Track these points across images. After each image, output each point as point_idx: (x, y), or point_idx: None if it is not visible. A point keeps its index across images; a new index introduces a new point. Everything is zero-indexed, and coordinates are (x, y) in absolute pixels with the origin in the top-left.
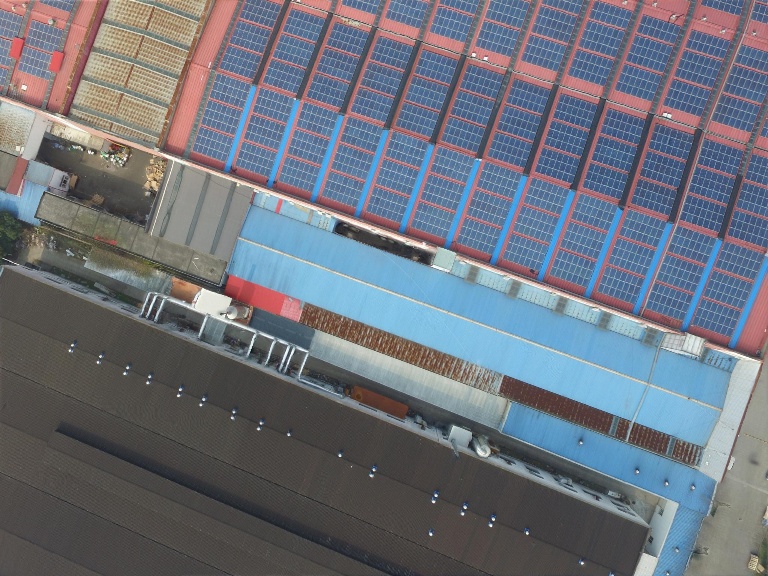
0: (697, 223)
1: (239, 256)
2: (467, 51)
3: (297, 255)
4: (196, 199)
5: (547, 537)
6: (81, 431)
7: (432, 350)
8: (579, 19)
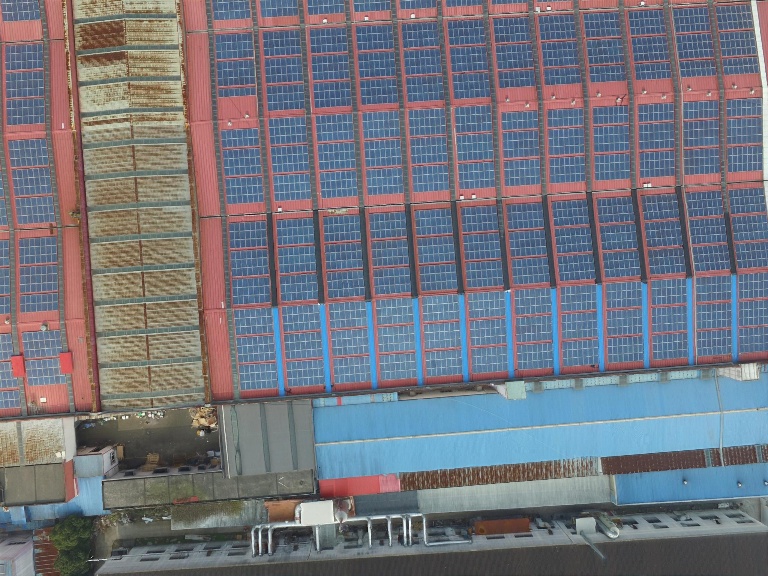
0: (710, 269)
1: (322, 460)
2: (454, 196)
3: (376, 436)
4: (258, 427)
5: None
6: None
7: (529, 462)
8: (540, 131)
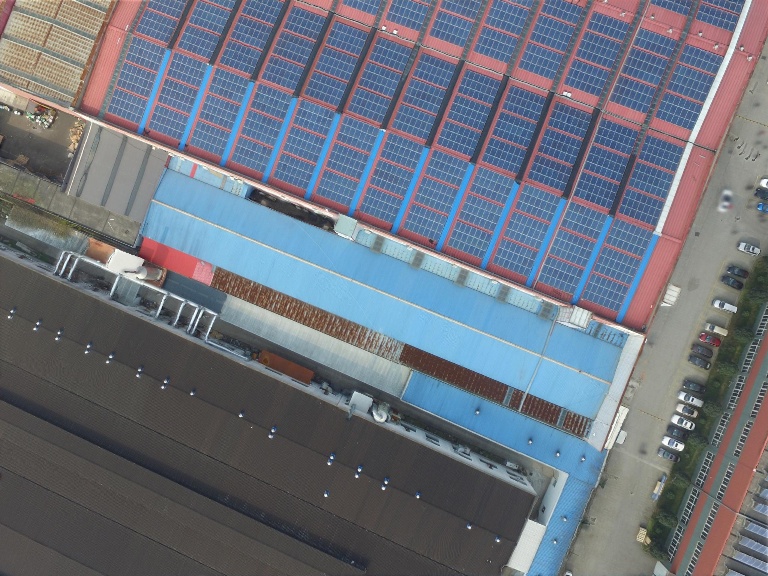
0: (590, 199)
1: (153, 218)
2: (378, 24)
3: (209, 219)
4: (113, 161)
5: (437, 501)
6: None
7: (338, 317)
8: None
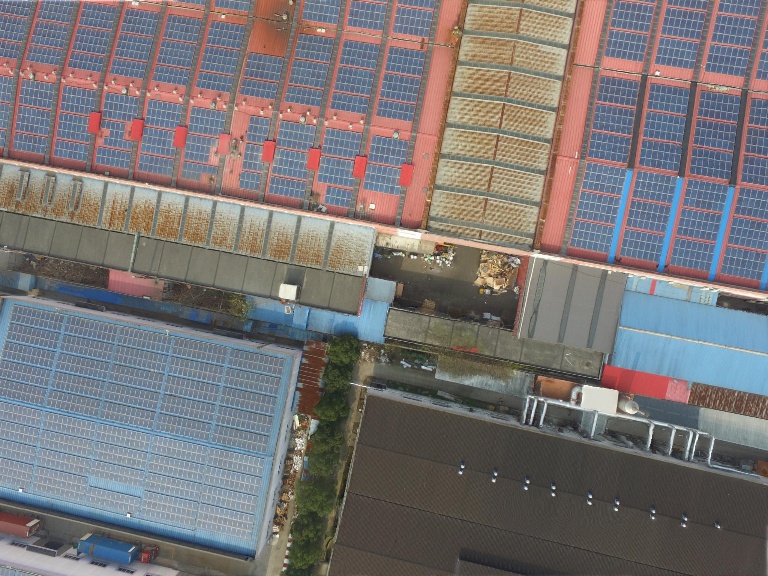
0: None
1: (620, 346)
2: None
3: (686, 336)
4: (564, 293)
5: None
6: (485, 555)
7: None
8: None
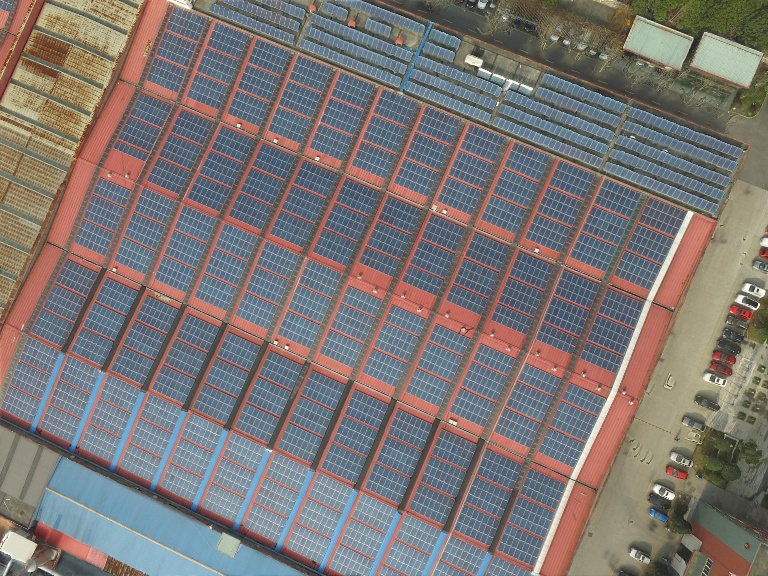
0: (470, 535)
1: (46, 505)
2: (270, 338)
3: (101, 511)
4: (9, 445)
5: None
6: None
7: None
8: (376, 320)
